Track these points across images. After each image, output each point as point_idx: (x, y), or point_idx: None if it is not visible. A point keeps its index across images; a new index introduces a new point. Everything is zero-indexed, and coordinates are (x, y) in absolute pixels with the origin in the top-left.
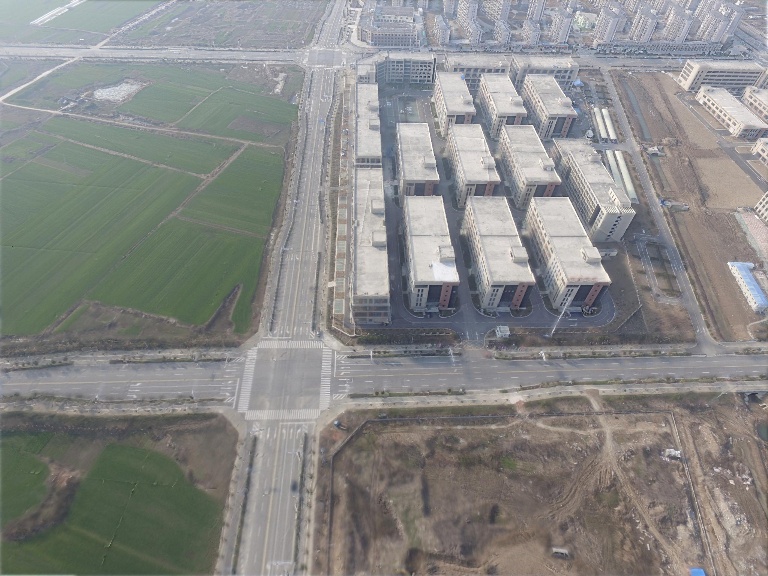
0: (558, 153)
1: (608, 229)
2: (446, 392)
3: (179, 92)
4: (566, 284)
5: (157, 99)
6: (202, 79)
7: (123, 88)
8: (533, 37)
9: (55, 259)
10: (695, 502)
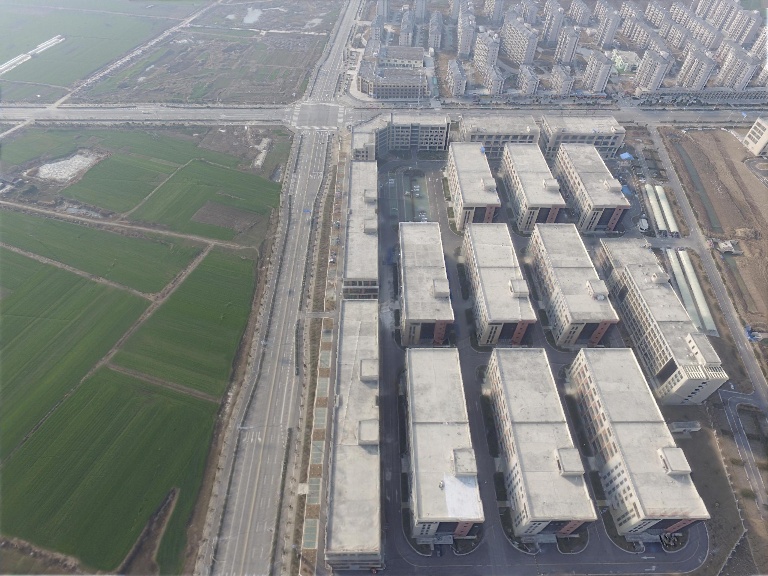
0: (607, 260)
1: (687, 393)
2: None
3: (140, 167)
4: (642, 518)
5: (112, 178)
6: (170, 148)
7: (75, 161)
8: (564, 86)
9: None
10: None
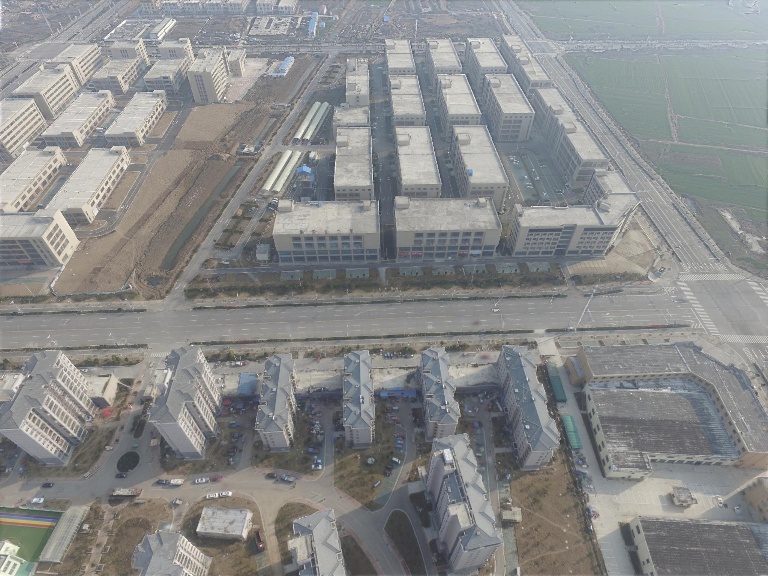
0: None
1: None
2: None
3: None
4: None
5: None
6: None
7: None
8: None
9: (703, 75)
10: None
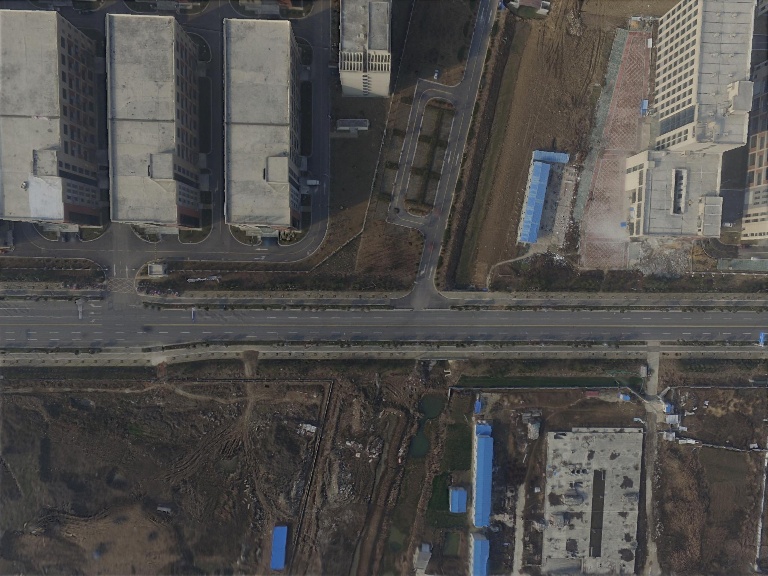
0: None
1: (358, 85)
2: (74, 352)
3: None
4: None
5: None
6: None
7: None
8: None
9: None
10: (311, 472)
